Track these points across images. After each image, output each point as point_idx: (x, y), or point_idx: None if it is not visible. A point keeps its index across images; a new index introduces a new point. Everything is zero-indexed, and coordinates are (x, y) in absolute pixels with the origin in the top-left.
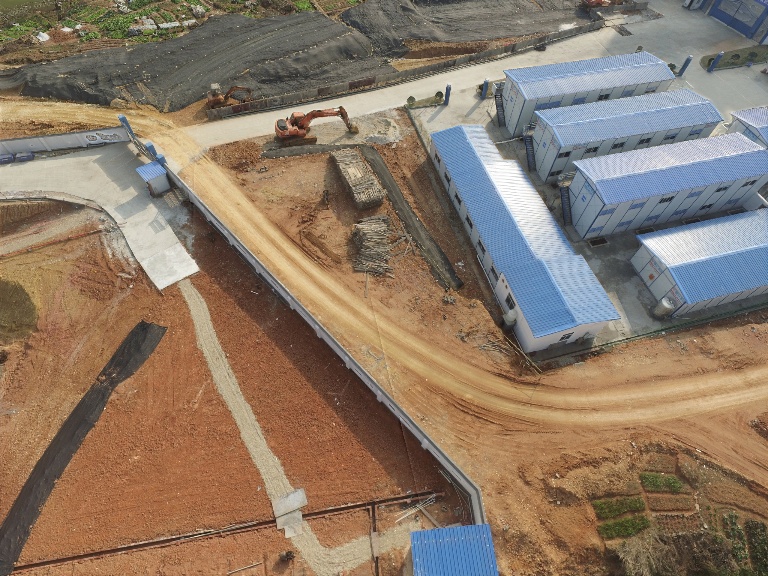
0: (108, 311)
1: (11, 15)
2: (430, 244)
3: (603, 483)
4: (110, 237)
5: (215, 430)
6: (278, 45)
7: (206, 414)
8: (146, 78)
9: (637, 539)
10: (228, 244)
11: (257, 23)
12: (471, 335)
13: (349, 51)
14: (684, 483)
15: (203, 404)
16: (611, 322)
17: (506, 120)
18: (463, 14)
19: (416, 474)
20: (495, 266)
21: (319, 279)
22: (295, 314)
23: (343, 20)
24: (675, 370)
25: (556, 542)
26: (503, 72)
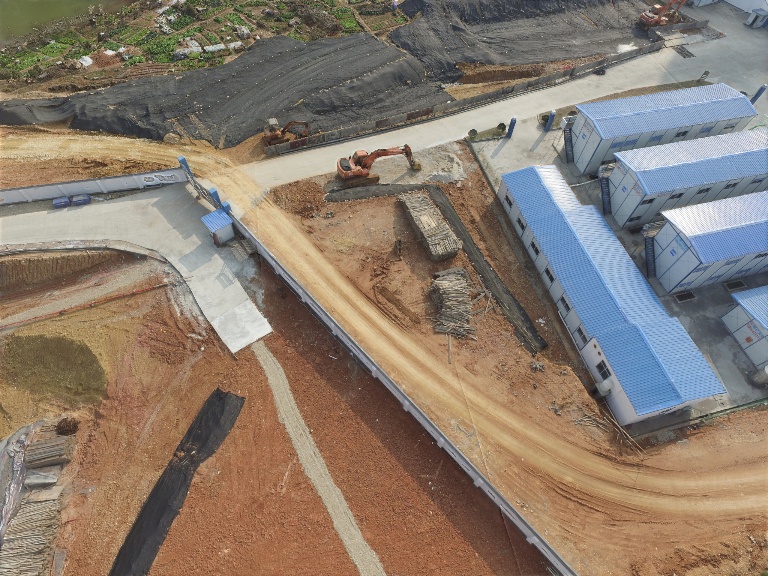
0: (180, 376)
1: (47, 32)
2: (508, 298)
3: None
4: (176, 292)
5: (306, 519)
6: (331, 72)
7: (295, 500)
8: (198, 110)
9: None
10: (300, 301)
11: (307, 47)
12: (565, 408)
13: (403, 77)
14: None
15: (291, 488)
16: None
17: (575, 156)
18: (515, 33)
19: (523, 572)
20: (585, 329)
21: (399, 342)
22: (378, 383)
23: (392, 41)
24: None
25: None
26: (564, 99)
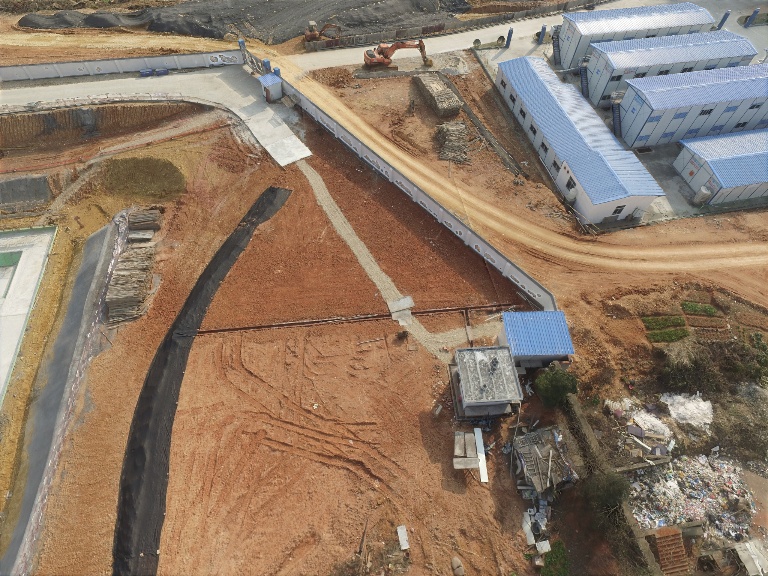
0: (242, 180)
1: None
2: (499, 148)
3: (651, 305)
4: (238, 129)
5: (338, 257)
6: None
7: (330, 246)
8: (251, 19)
9: (679, 343)
10: (333, 137)
11: None
12: (538, 206)
13: (420, 5)
14: (718, 310)
15: (327, 240)
16: (656, 207)
17: (561, 59)
18: None
19: (499, 292)
20: (558, 157)
21: (410, 164)
22: (393, 185)
23: None
24: (711, 238)
25: (613, 341)
26: None
